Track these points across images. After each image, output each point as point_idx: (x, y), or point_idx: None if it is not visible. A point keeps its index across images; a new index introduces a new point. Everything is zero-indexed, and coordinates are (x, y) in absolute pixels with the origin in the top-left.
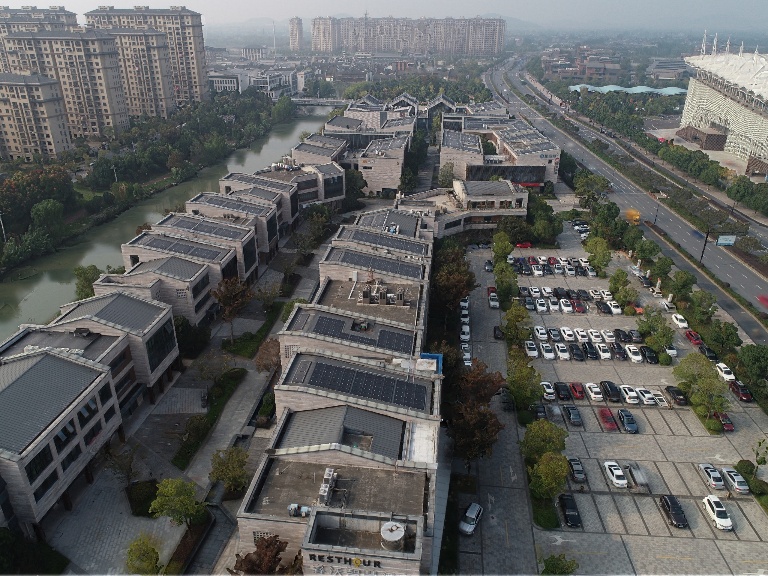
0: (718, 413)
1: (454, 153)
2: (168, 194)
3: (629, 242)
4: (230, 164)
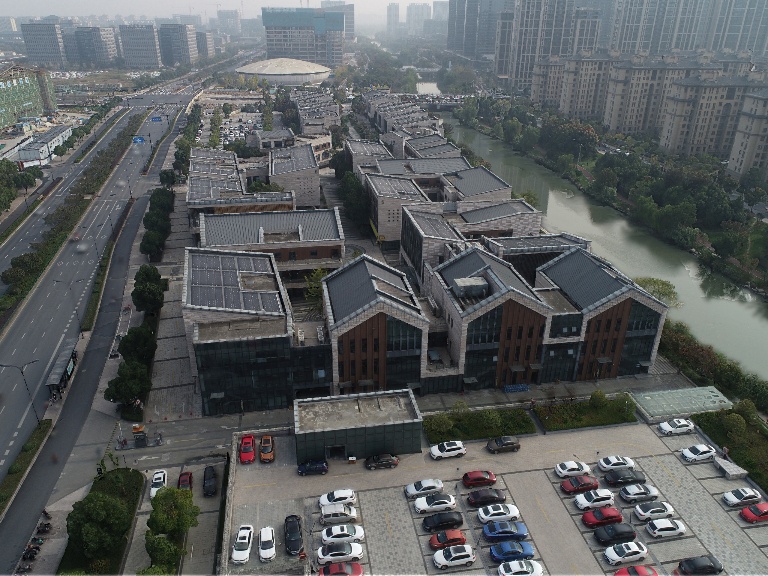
0: None
1: None
2: (563, 184)
3: None
4: (611, 221)
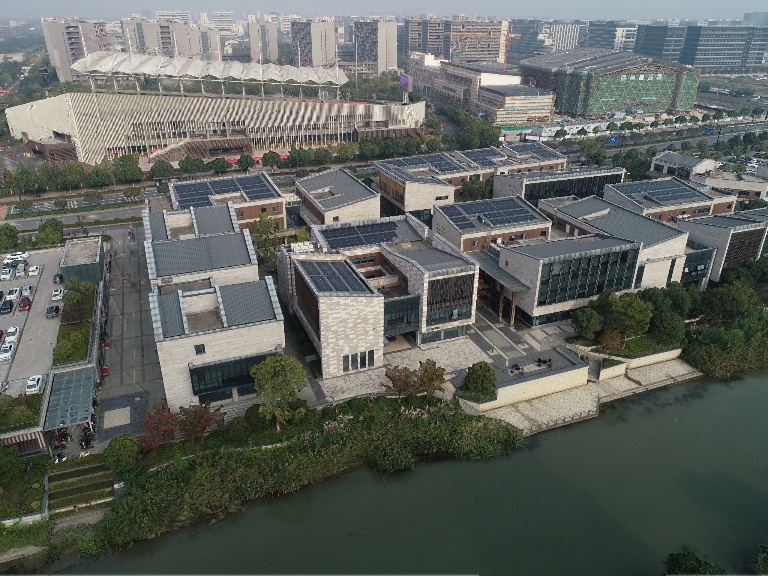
0: None
1: None
2: None
3: None
4: None
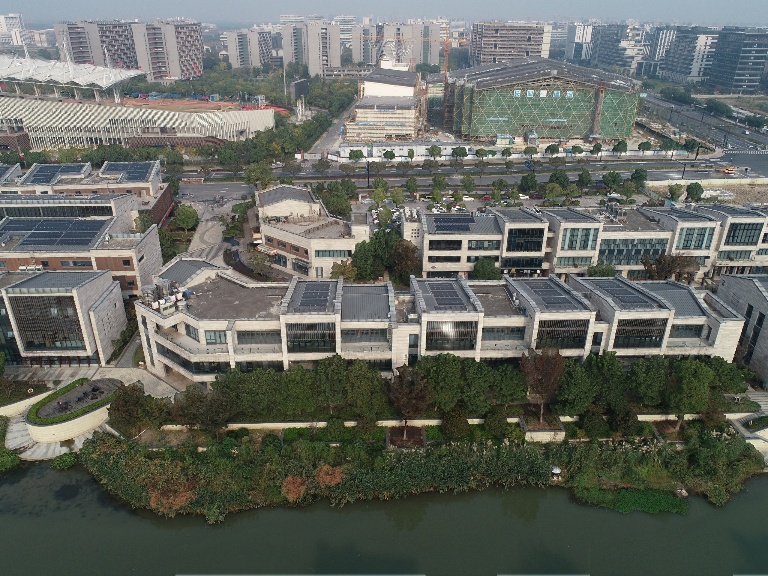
0: (567, 200)
1: (122, 204)
2: None
3: (354, 191)
4: None
